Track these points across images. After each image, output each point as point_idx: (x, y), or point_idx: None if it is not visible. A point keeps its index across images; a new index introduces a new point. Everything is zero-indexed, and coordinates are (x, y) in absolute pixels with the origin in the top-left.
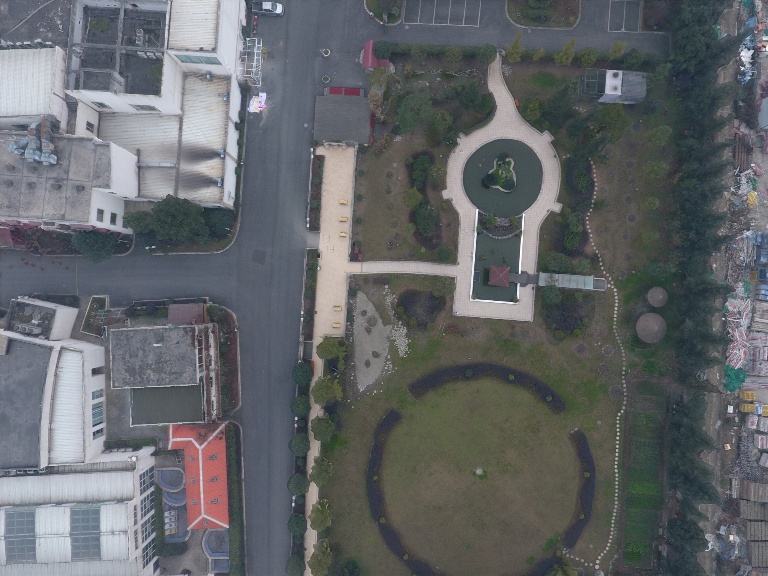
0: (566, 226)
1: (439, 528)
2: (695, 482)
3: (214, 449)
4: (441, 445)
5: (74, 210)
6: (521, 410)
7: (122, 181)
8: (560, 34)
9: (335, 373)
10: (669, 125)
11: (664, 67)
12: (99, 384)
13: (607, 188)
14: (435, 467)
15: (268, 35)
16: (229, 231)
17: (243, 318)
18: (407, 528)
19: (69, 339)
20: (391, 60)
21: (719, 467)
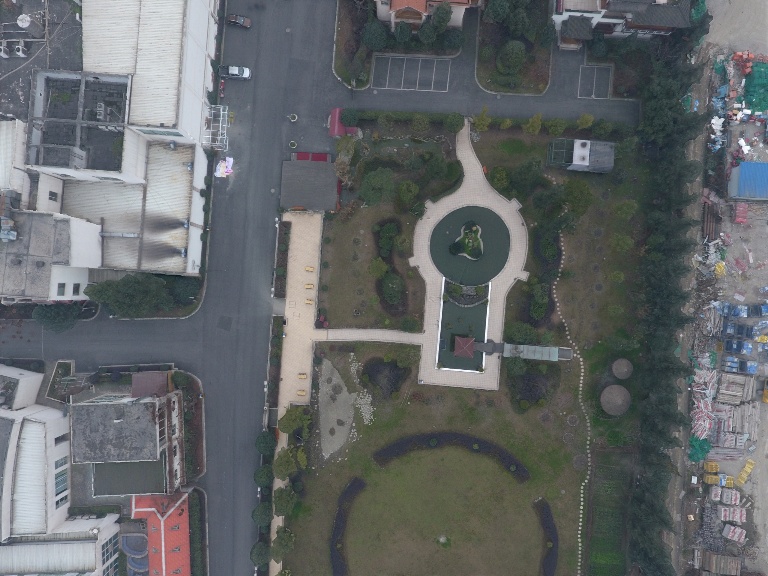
0: (533, 295)
1: None
2: (654, 561)
3: (177, 519)
4: (405, 513)
5: (34, 286)
6: (485, 479)
7: (83, 255)
8: (529, 100)
9: (298, 444)
10: (638, 193)
11: (631, 141)
12: (63, 452)
13: (574, 257)
14: (399, 535)
15: (235, 99)
16: (194, 297)
17: (208, 384)
18: None
19: (34, 405)
20: (359, 125)
21: (682, 537)
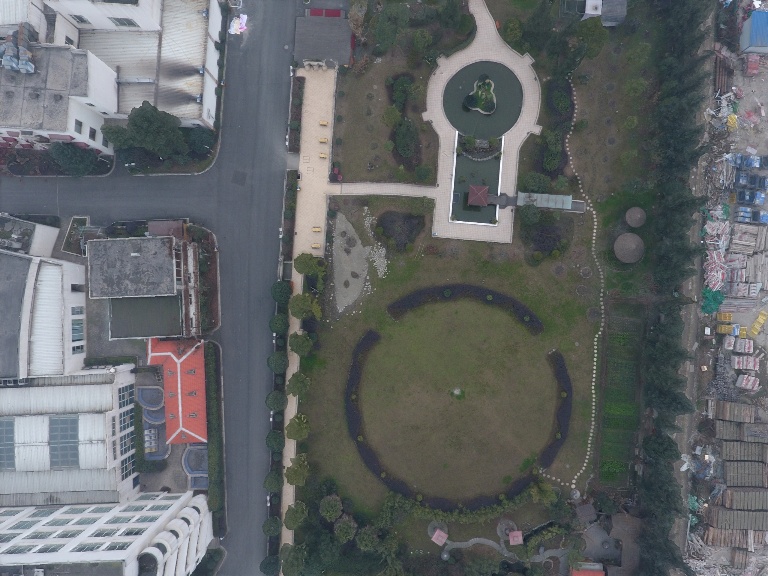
0: (545, 148)
1: (417, 447)
2: (669, 394)
3: (193, 364)
4: (419, 365)
5: (52, 119)
6: (499, 331)
7: (100, 93)
8: None
9: (313, 290)
10: (650, 48)
11: None
12: (79, 301)
13: (587, 111)
14: (413, 387)
15: None
16: (209, 152)
17: (223, 239)
18: (385, 447)
19: (50, 258)
20: None
21: (696, 388)
